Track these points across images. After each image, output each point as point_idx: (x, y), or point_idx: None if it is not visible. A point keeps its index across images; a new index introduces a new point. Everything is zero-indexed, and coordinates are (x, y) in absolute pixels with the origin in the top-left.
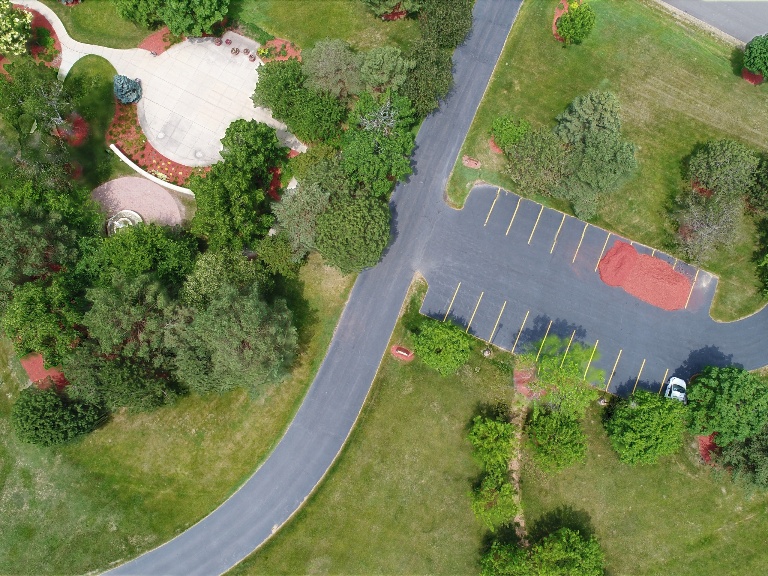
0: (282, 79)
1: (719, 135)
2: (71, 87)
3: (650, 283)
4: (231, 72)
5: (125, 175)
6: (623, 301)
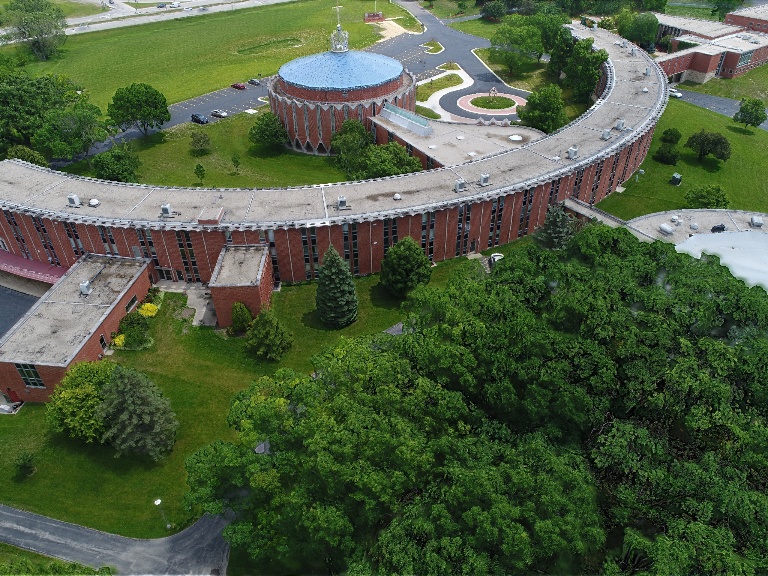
0: None
1: (453, 3)
2: None
3: None
4: None
5: None
6: None
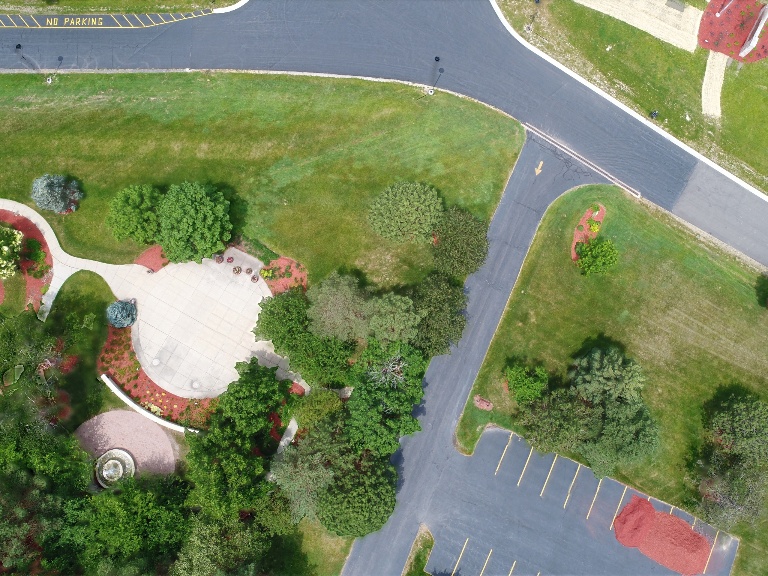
0: (286, 325)
1: (743, 376)
2: (62, 306)
3: (668, 549)
4: (232, 293)
5: (116, 408)
6: (639, 564)
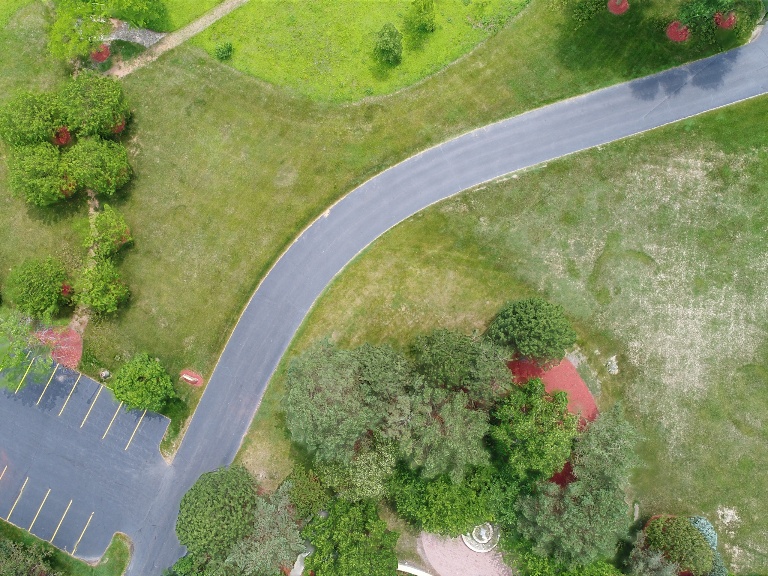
0: None
1: None
2: None
3: None
4: None
5: None
6: None
